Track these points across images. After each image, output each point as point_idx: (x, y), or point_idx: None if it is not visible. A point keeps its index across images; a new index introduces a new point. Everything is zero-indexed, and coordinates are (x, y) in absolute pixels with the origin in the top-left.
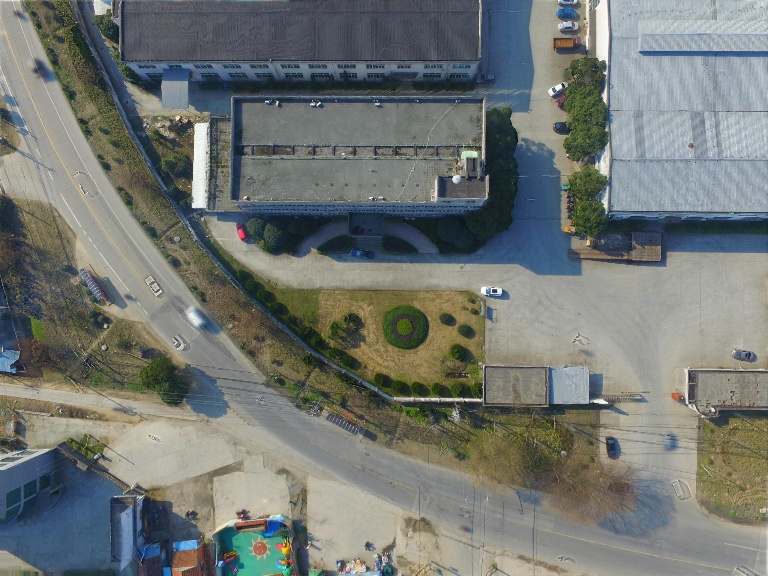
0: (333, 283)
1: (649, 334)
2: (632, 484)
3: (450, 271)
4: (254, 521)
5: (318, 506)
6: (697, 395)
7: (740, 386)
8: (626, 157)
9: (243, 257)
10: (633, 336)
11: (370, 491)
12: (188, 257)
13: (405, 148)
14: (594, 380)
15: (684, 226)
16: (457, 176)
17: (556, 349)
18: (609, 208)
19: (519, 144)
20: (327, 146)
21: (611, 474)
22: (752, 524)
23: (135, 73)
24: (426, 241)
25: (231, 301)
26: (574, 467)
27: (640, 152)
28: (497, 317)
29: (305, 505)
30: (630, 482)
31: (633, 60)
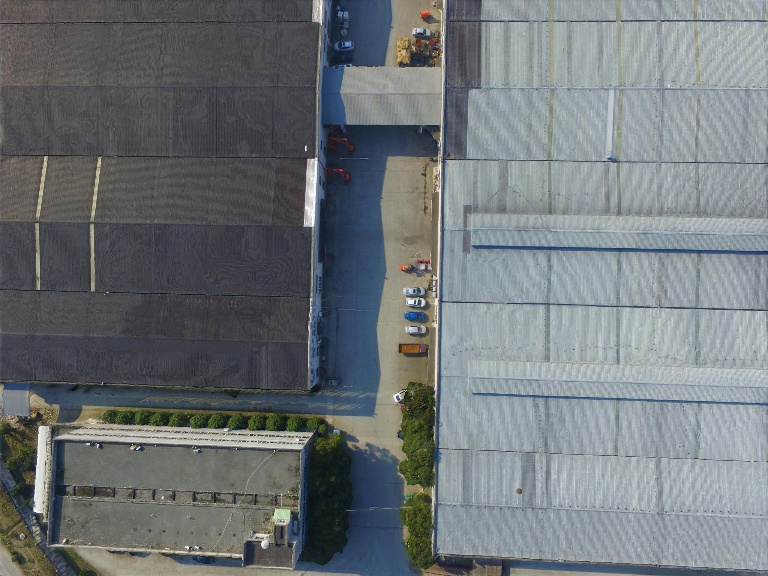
0: None
1: None
2: None
3: None
4: None
5: None
6: None
7: None
8: (452, 502)
9: (87, 554)
10: None
11: None
12: (33, 555)
13: (224, 494)
14: None
15: None
16: (265, 542)
17: None
18: (434, 552)
19: (363, 449)
20: (147, 489)
21: None
22: None
23: None
24: None
25: None
26: None
27: (467, 496)
28: None
29: None
30: None
31: (463, 399)
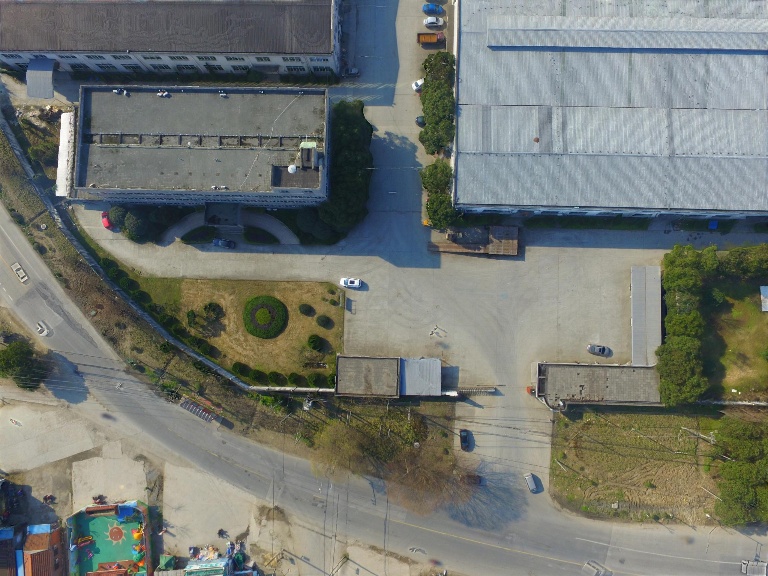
0: (196, 272)
1: (506, 328)
2: (485, 477)
3: (311, 262)
4: (106, 506)
5: (174, 493)
6: (547, 389)
7: (589, 380)
8: (472, 150)
9: (109, 245)
10: (490, 329)
11: (225, 479)
12: (54, 244)
13: (250, 138)
14: (450, 372)
15: (542, 221)
16: (292, 166)
17: (413, 341)
18: (455, 201)
19: (382, 137)
20: (173, 135)
21: (465, 466)
22: (604, 519)
23: (5, 63)
24: (288, 232)
25: (94, 288)
26: (427, 459)
27: (486, 146)
28: (356, 308)
29: (161, 491)
30: (483, 475)
31: (482, 55)
